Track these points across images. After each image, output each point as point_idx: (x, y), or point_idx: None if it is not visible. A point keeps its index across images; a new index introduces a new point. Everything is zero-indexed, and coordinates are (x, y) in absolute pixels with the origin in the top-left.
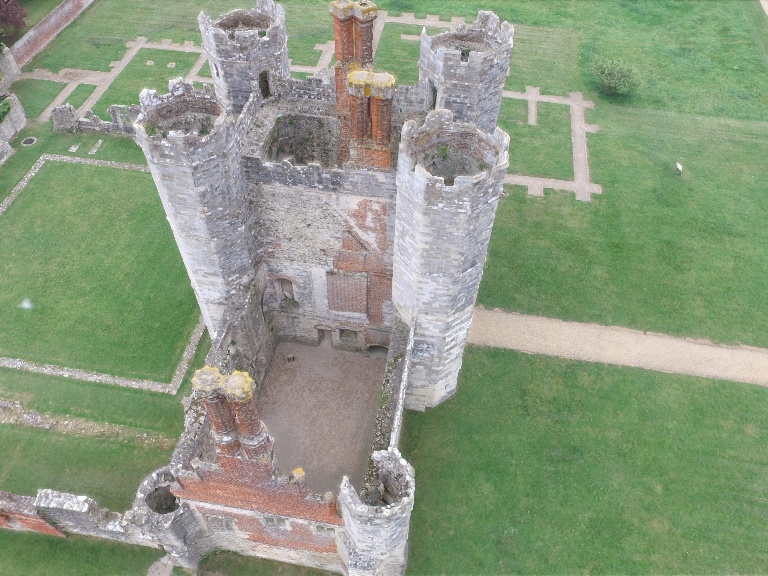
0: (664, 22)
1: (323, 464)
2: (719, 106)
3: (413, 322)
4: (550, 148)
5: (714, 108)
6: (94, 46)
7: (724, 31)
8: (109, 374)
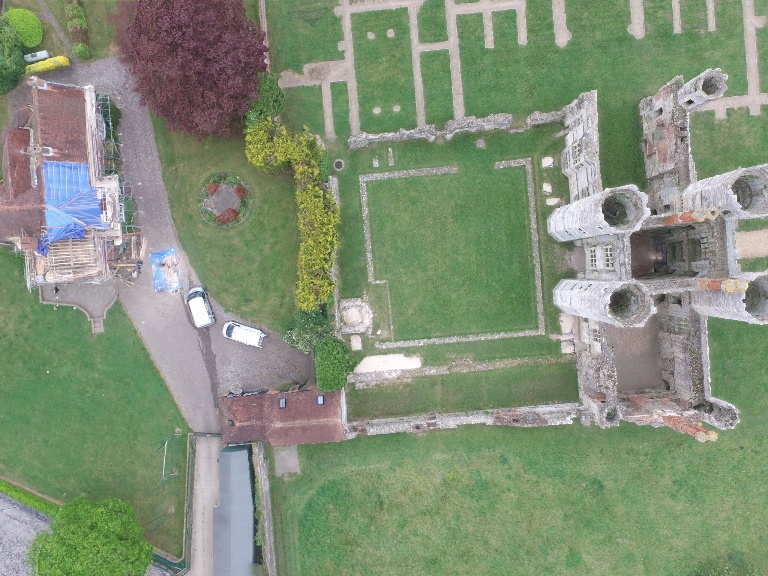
0: None
1: (633, 352)
2: None
3: (707, 319)
4: (728, 59)
5: None
6: (309, 24)
7: None
8: (504, 332)
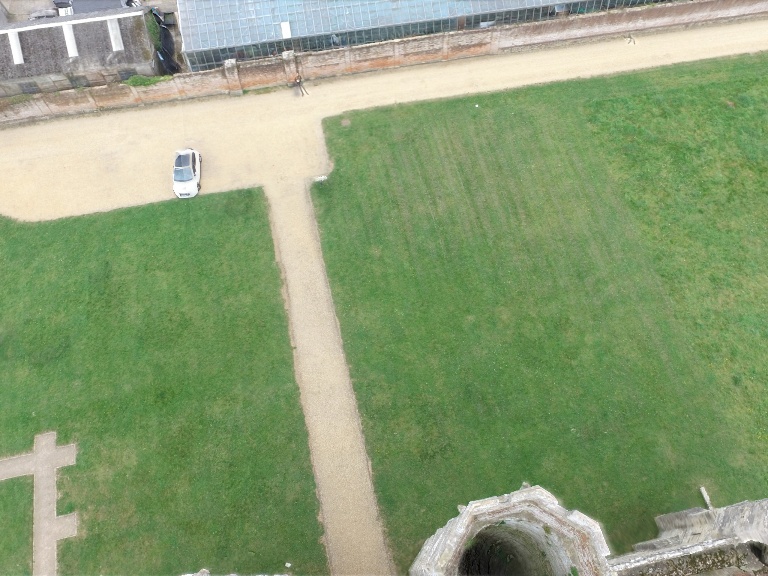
0: None
1: None
2: None
3: None
4: None
5: None
6: None
7: None
8: None
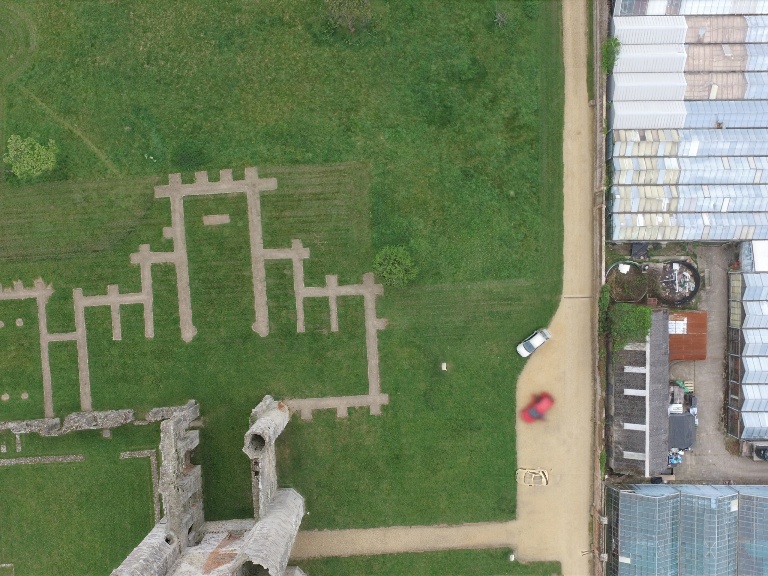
0: (454, 117)
1: None
2: (487, 265)
3: None
4: (350, 360)
5: (483, 269)
6: None
7: (512, 120)
8: None
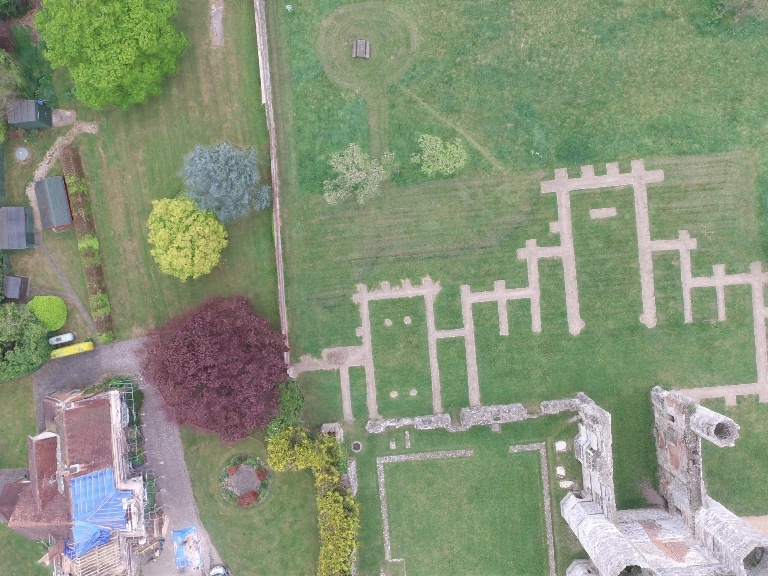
0: None
1: None
2: None
3: None
4: (738, 348)
5: None
6: (327, 311)
7: None
8: None
